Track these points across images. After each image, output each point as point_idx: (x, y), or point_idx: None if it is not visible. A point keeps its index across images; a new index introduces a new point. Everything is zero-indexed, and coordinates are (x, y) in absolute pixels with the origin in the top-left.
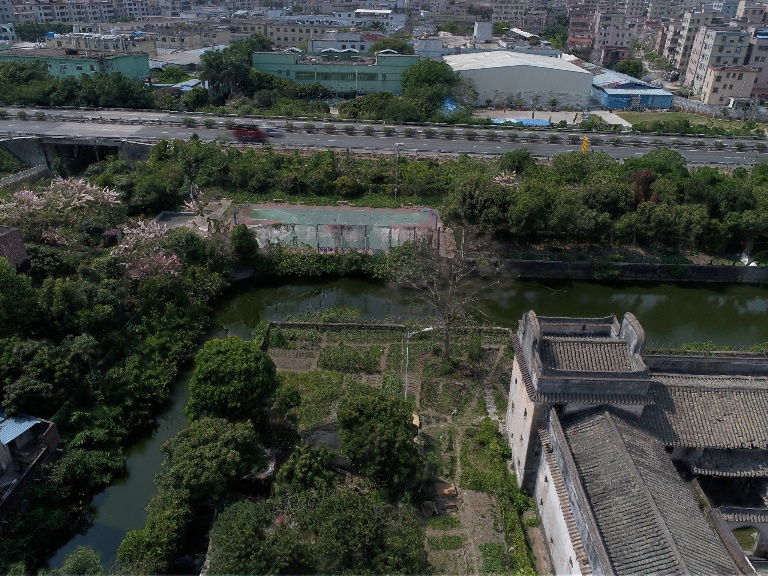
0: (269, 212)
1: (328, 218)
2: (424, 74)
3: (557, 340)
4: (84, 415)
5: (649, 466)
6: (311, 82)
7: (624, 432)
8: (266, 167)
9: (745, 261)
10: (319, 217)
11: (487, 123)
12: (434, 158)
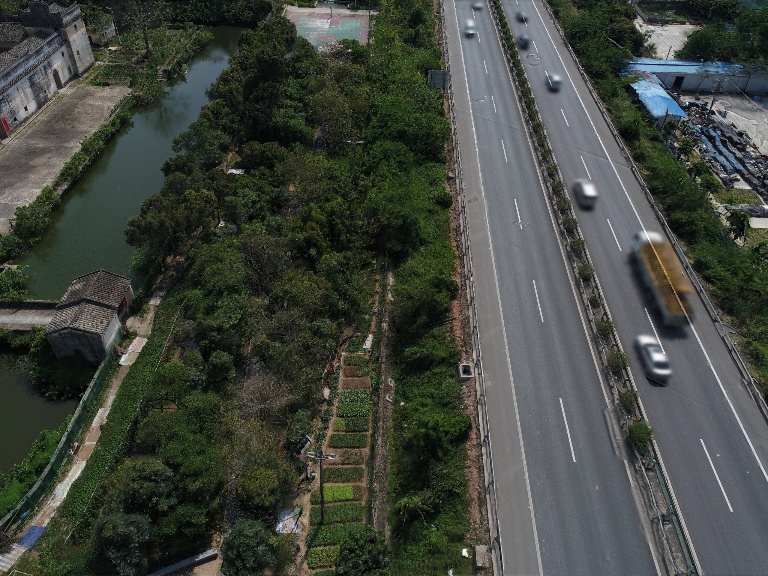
0: (354, 23)
1: (342, 36)
2: (748, 18)
3: (53, 3)
4: (138, 1)
5: (4, 29)
6: (747, 2)
7: (20, 27)
8: (402, 3)
9: (237, 170)
10: (344, 34)
11: (598, 72)
12: (441, 46)
